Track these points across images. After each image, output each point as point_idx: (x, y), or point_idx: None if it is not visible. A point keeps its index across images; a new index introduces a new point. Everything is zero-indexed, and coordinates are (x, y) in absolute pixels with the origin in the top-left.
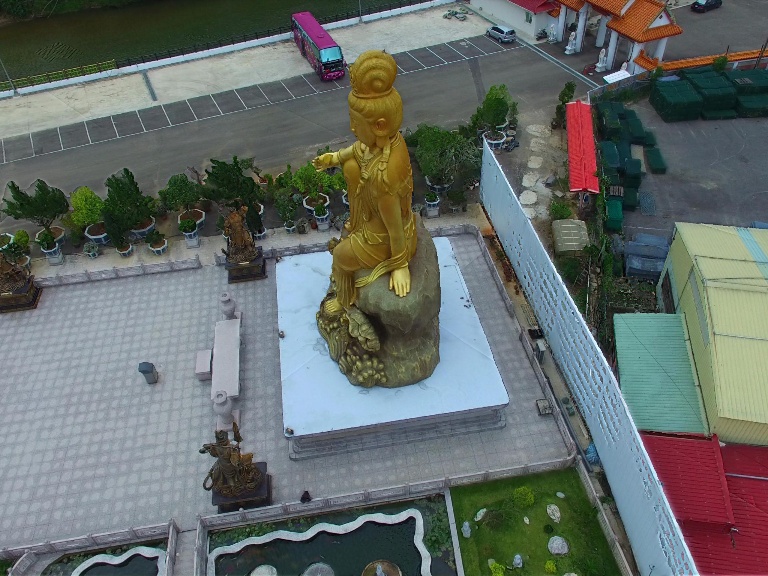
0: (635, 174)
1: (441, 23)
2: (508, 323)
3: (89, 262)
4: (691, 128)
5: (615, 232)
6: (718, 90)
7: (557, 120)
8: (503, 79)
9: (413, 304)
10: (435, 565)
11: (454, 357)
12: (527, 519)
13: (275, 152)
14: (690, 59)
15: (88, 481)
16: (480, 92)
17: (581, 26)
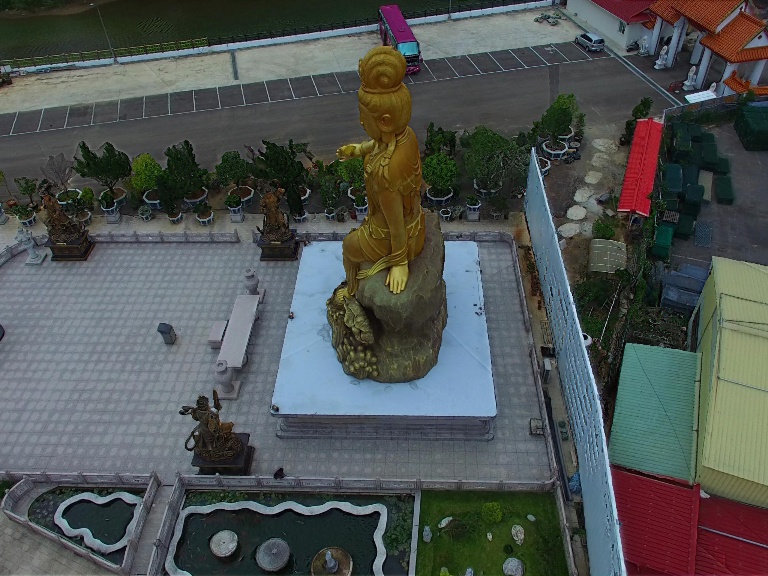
0: (694, 201)
1: (531, 26)
2: (522, 337)
3: (142, 224)
4: None
5: (660, 259)
6: None
7: (626, 136)
8: (581, 89)
9: (405, 302)
10: (389, 562)
11: (452, 362)
12: (490, 535)
13: (335, 140)
14: None
15: (93, 424)
16: (553, 100)
17: (675, 40)
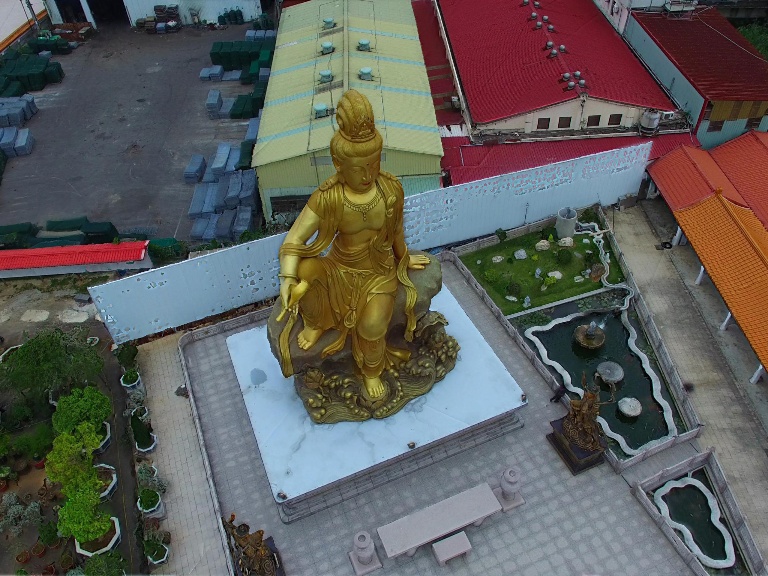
0: (110, 225)
1: None
2: None
3: None
4: (8, 204)
5: None
6: None
7: None
8: None
9: None
10: None
11: None
12: None
13: None
14: None
15: None
16: None
17: None
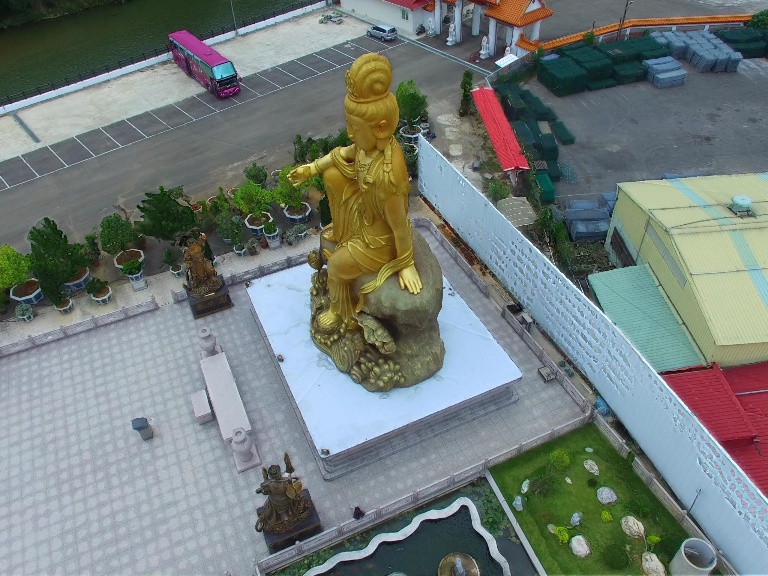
0: (553, 147)
1: (319, 28)
2: (486, 304)
3: (25, 327)
4: (581, 99)
5: (550, 203)
6: (596, 62)
7: (464, 108)
8: (398, 76)
9: (429, 299)
10: (500, 545)
11: (457, 344)
12: (569, 479)
13: (194, 177)
14: (564, 37)
15: (113, 559)
16: None
17: (458, 17)
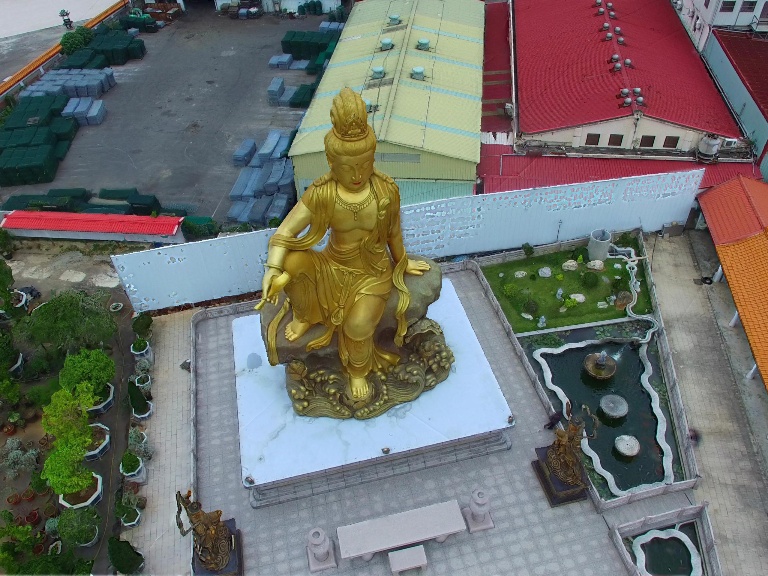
0: (154, 199)
1: None
2: None
3: None
4: (71, 170)
5: None
6: (38, 136)
7: (7, 248)
8: None
9: None
10: None
11: None
12: None
13: None
14: None
15: None
16: None
17: None
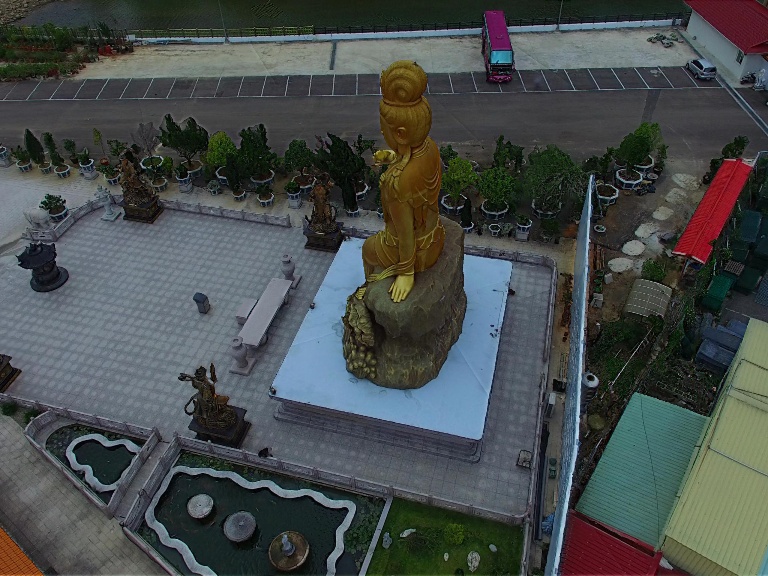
0: (764, 255)
1: (642, 46)
2: (537, 366)
3: (209, 197)
4: None
5: (711, 311)
6: None
7: (710, 175)
8: (677, 118)
9: (402, 312)
10: (344, 559)
11: (452, 378)
12: (447, 555)
13: None
14: None
15: (119, 374)
16: None
17: None
